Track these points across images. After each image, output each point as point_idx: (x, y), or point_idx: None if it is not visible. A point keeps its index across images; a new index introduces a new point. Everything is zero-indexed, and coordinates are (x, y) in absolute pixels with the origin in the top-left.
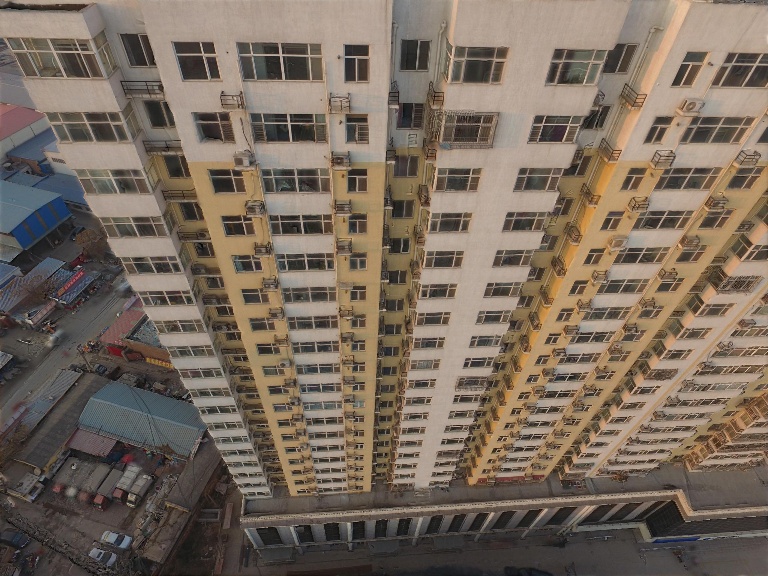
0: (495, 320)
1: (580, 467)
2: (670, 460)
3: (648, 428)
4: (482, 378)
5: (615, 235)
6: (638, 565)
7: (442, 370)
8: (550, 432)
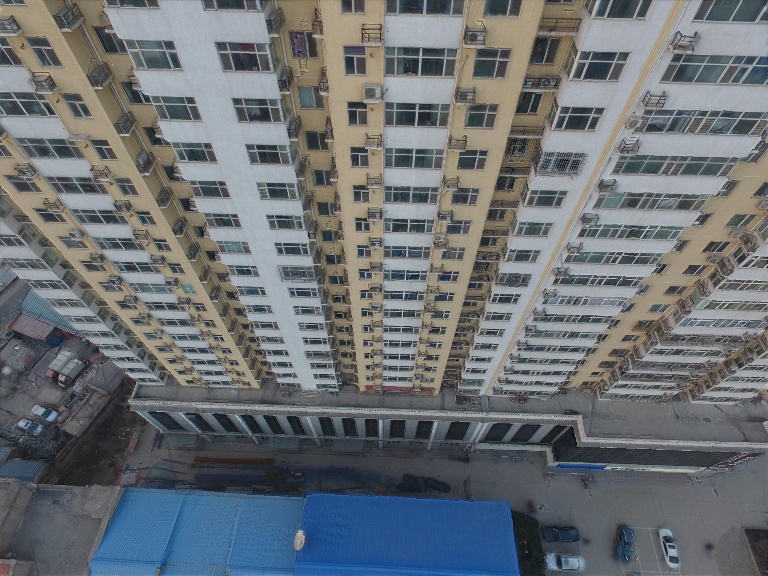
0: (285, 196)
1: (472, 383)
2: (579, 386)
3: (524, 344)
4: (308, 269)
5: (367, 82)
6: (541, 486)
7: (256, 255)
8: (417, 340)
